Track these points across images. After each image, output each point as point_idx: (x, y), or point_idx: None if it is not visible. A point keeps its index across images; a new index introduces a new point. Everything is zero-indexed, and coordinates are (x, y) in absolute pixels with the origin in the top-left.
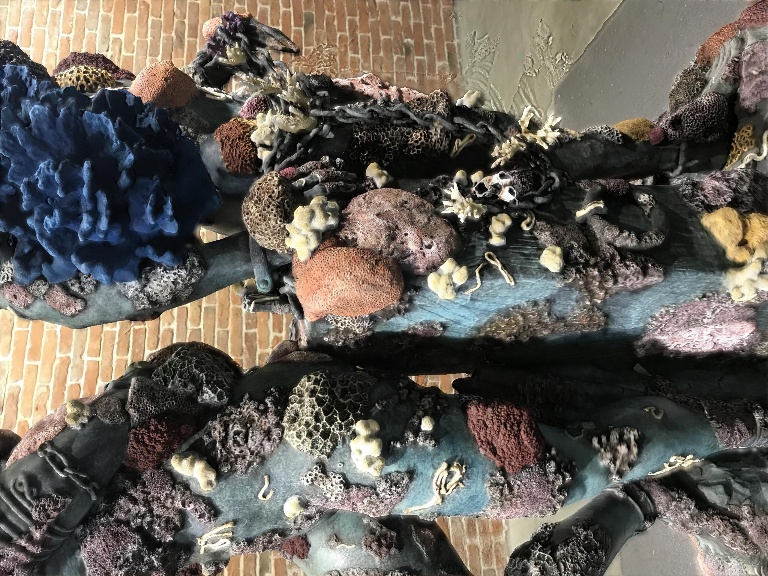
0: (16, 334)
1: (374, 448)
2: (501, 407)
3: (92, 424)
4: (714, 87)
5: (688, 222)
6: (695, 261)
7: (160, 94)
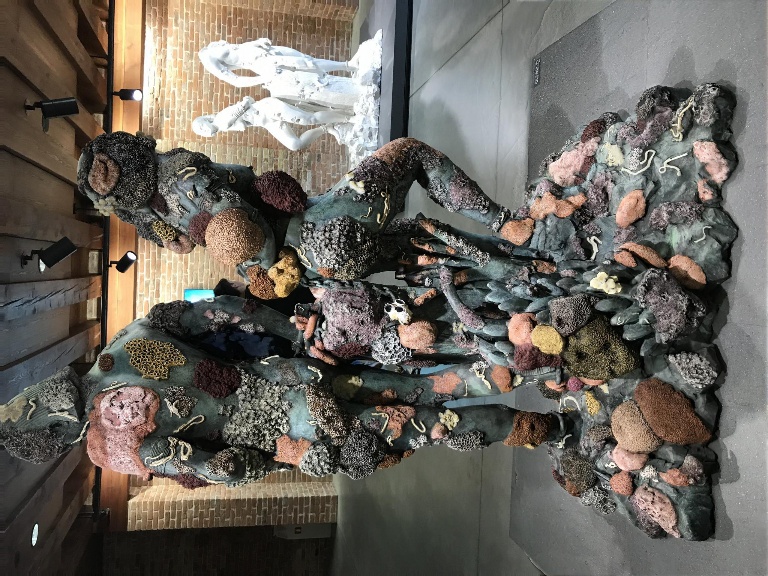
0: None
1: None
2: None
3: None
4: None
5: None
6: None
7: None
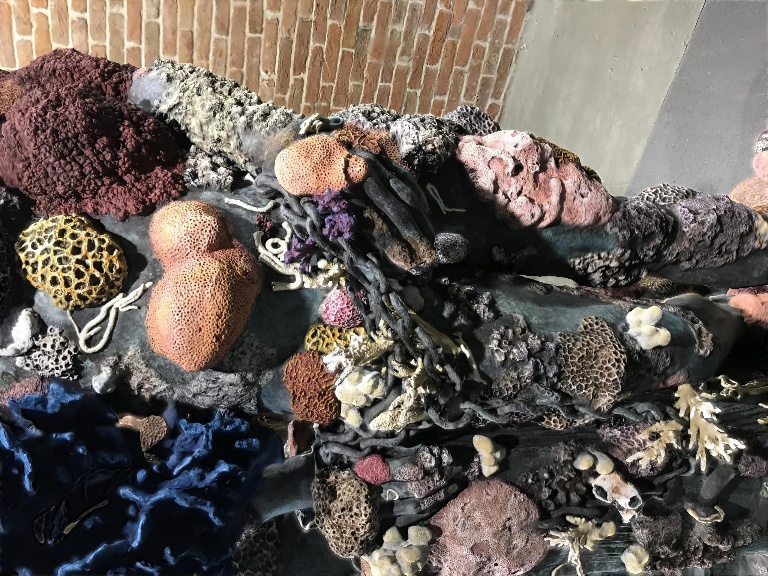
0: None
1: None
2: None
3: None
4: None
5: None
6: None
7: (210, 361)
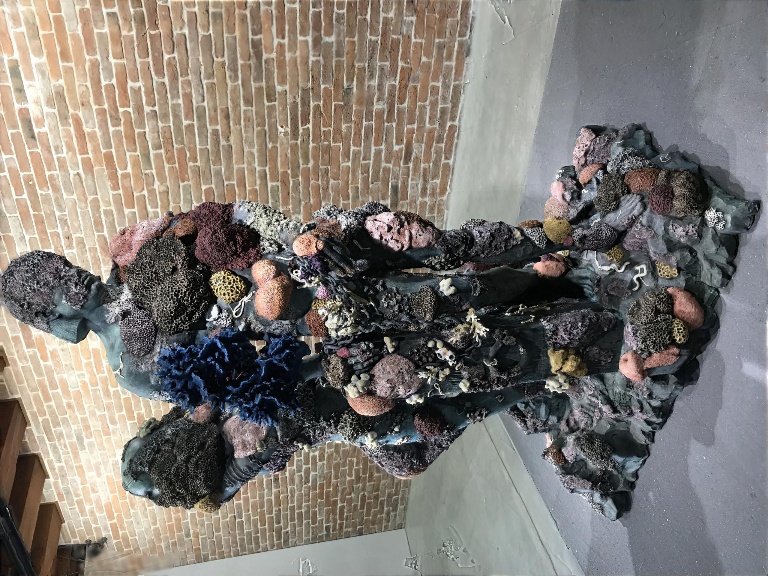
0: (44, 38)
1: (374, 445)
2: (429, 423)
3: (267, 450)
4: (615, 224)
5: (541, 351)
6: (534, 374)
7: (278, 316)
